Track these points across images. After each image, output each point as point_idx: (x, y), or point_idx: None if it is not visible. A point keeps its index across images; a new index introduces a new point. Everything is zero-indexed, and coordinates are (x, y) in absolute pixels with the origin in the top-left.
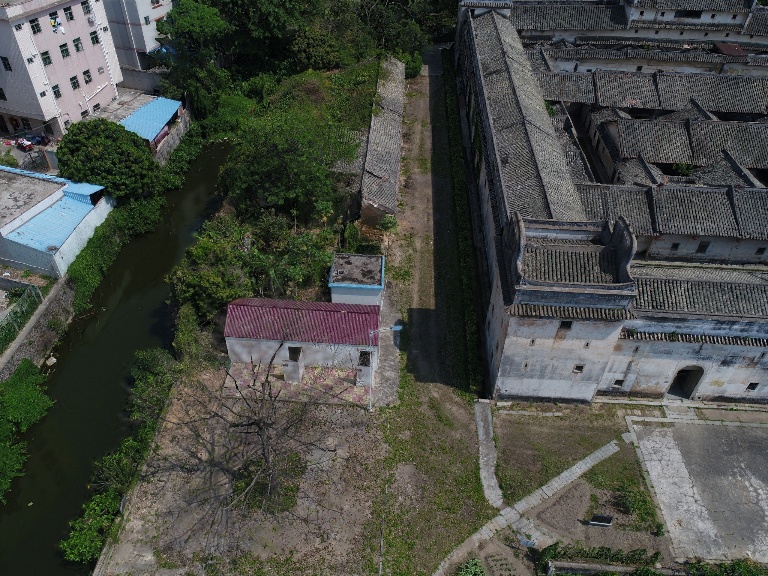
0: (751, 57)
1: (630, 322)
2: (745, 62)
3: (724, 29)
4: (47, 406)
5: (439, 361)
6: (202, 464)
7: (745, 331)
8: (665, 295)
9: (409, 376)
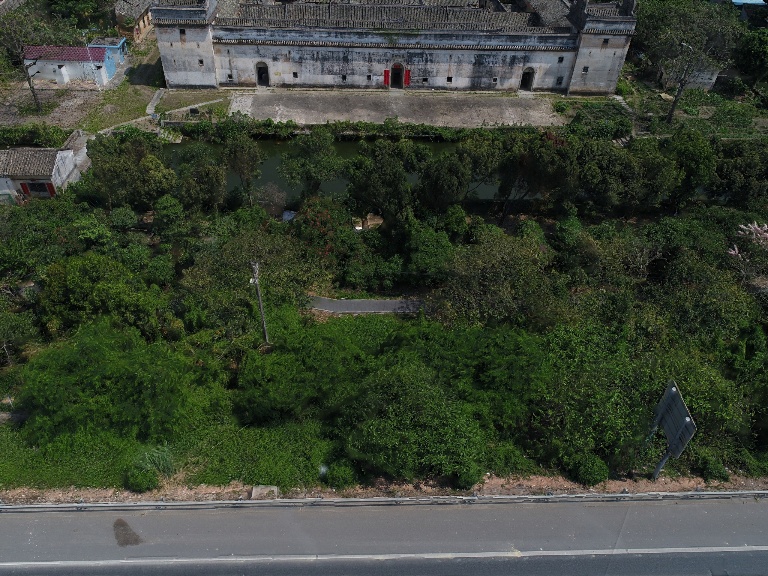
0: None
1: (217, 33)
2: None
3: None
4: None
5: (146, 79)
6: (6, 106)
7: (273, 36)
8: None
9: (127, 83)
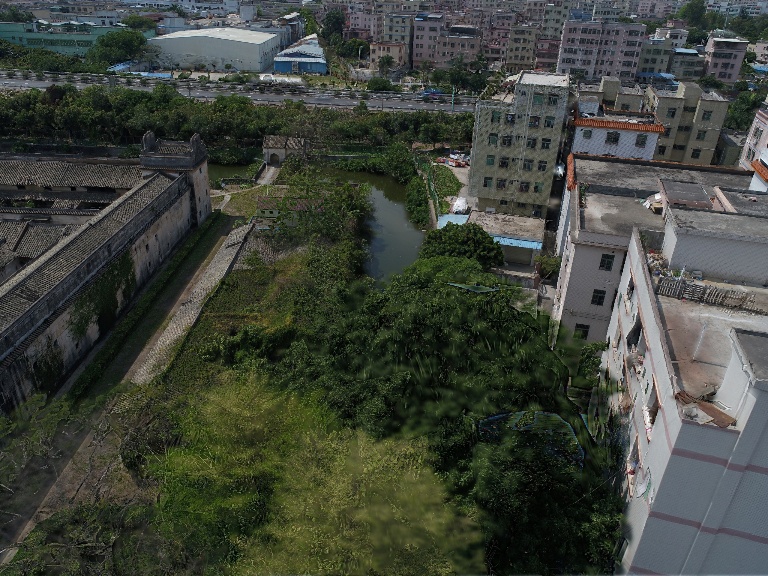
0: None
1: None
2: None
3: None
4: (411, 219)
5: None
6: None
7: None
8: None
9: None
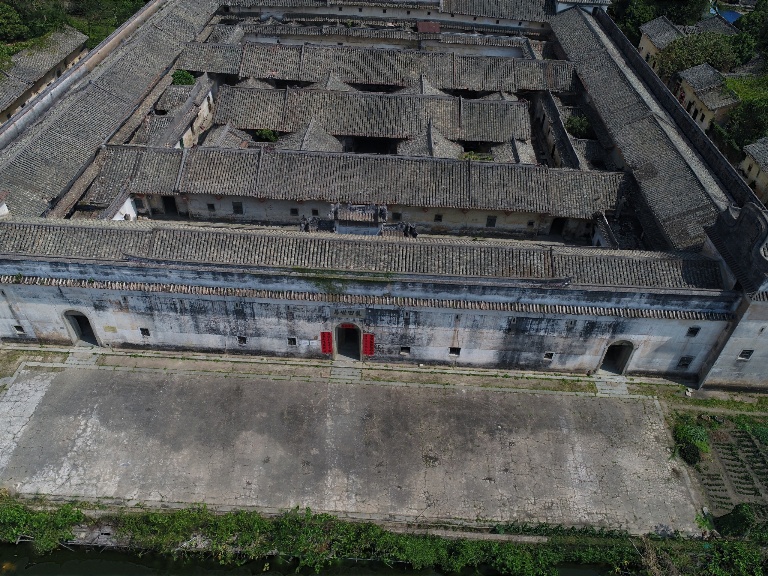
0: (444, 35)
1: None
2: (437, 39)
3: (421, 7)
4: None
5: None
6: None
7: (85, 273)
8: (33, 240)
9: None
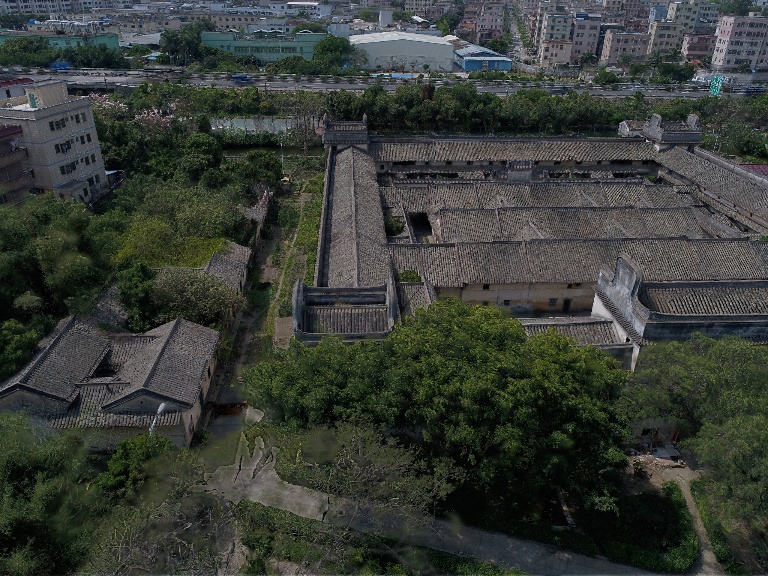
0: None
1: None
2: None
3: None
4: None
5: None
6: None
7: None
8: None
9: None
